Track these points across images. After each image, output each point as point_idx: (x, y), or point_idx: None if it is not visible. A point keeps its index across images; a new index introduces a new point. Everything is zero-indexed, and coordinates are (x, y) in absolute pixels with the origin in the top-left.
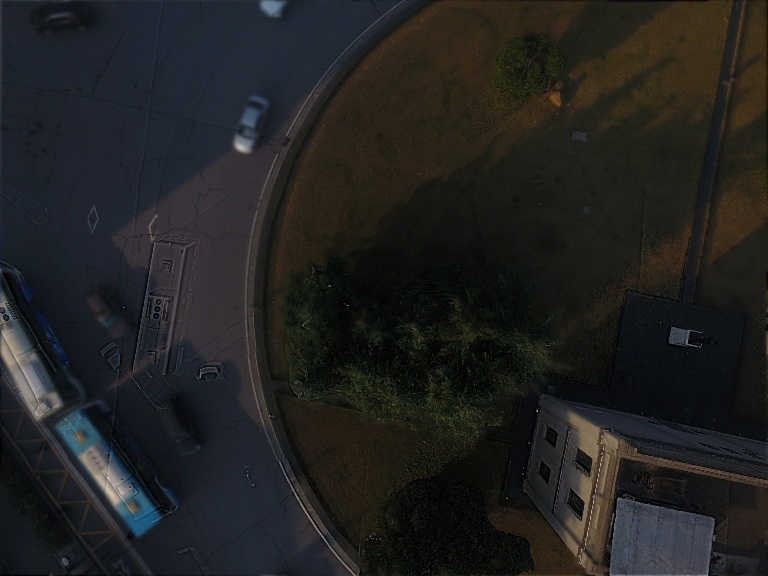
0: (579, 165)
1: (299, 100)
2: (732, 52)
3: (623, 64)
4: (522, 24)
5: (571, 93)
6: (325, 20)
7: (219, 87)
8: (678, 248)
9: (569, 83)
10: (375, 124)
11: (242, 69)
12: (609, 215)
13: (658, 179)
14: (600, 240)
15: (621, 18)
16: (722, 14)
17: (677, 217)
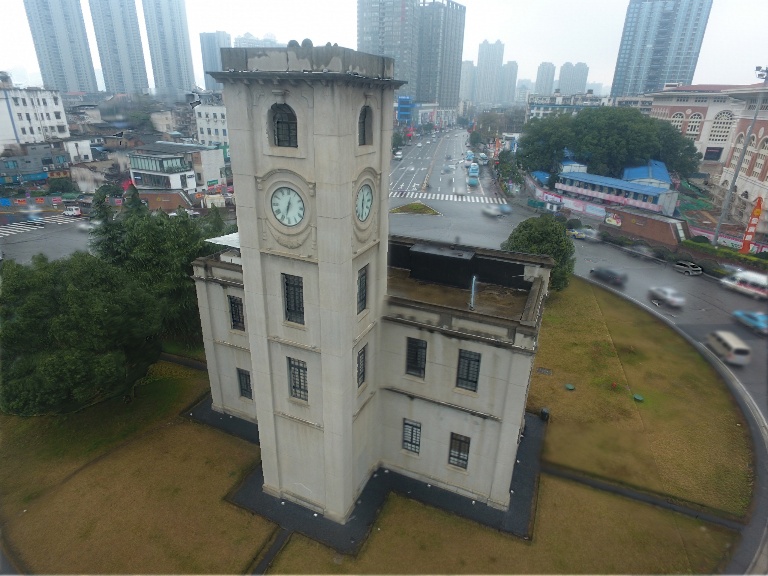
0: None
1: None
2: None
3: None
4: None
5: None
6: None
7: None
8: None
9: None
10: None
11: None
12: None
13: None
14: None
15: None
16: None
17: None
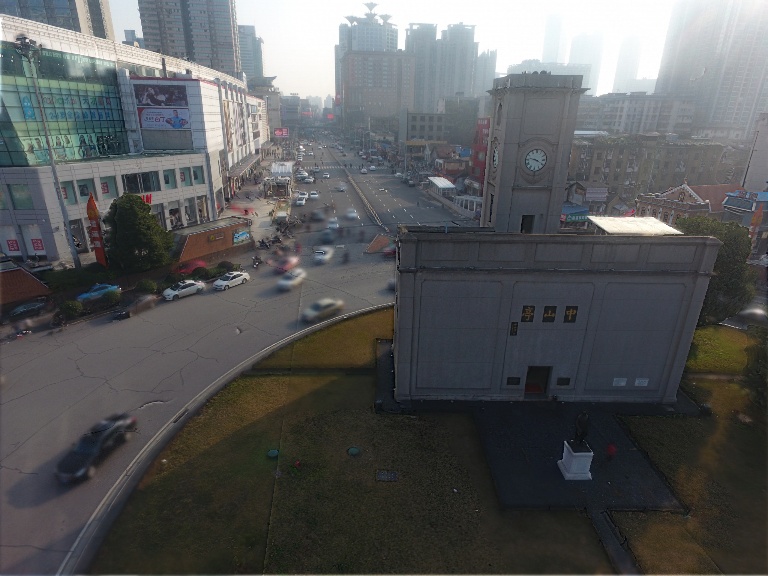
0: None
1: None
2: None
3: None
4: None
5: None
6: None
7: None
8: None
9: None
10: None
11: None
12: None
13: None
14: None
15: None
16: None
17: None
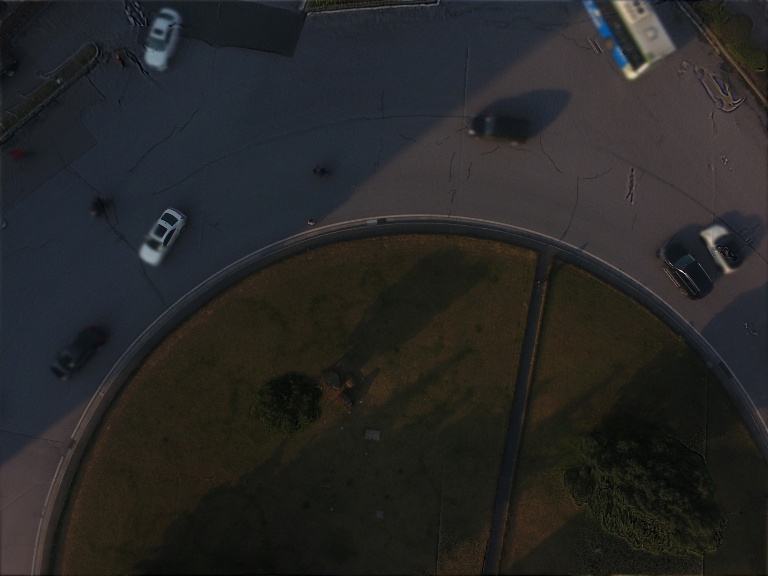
0: (372, 467)
1: (84, 399)
2: (533, 339)
3: (418, 357)
4: (313, 316)
5: (363, 390)
6: (111, 313)
7: (2, 387)
8: (476, 551)
9: (362, 378)
10: (161, 426)
11: (25, 367)
12: (403, 519)
13: (454, 479)
14: (394, 546)
15: (416, 307)
16: (522, 299)
17: (475, 518)
